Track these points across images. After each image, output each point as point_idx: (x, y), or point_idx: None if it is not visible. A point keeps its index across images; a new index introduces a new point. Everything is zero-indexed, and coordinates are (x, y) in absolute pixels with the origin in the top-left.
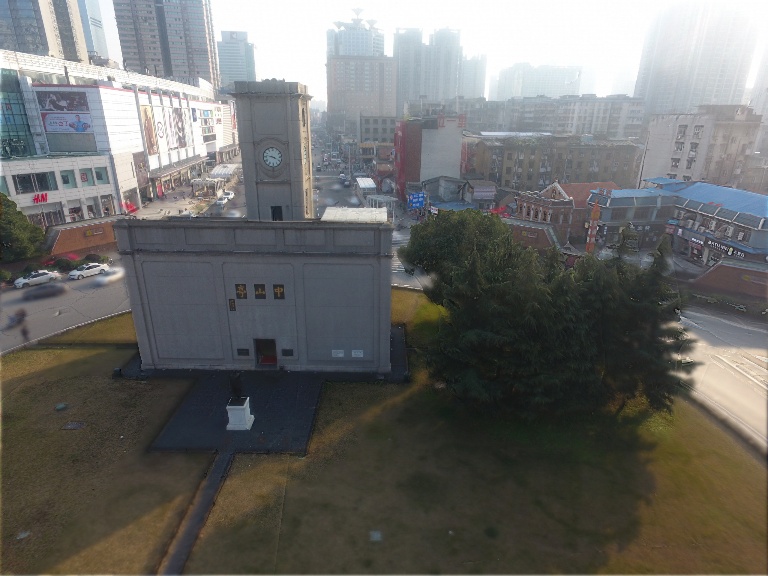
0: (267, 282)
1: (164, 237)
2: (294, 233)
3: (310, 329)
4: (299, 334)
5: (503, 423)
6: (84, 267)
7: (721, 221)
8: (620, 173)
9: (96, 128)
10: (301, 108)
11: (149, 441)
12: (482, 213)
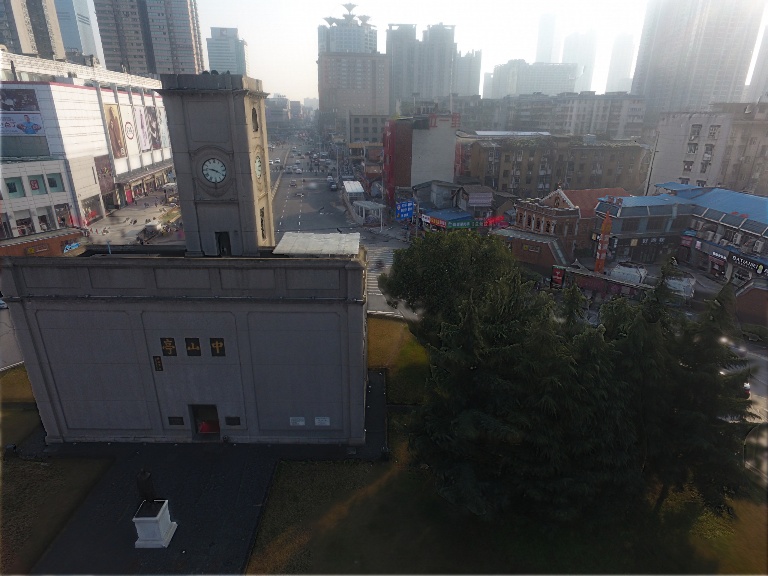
0: (202, 335)
1: (62, 279)
2: (234, 273)
3: (260, 392)
4: (246, 399)
5: (510, 529)
6: None
7: (747, 234)
8: (625, 176)
9: (48, 130)
10: (250, 108)
11: (23, 570)
12: (478, 222)
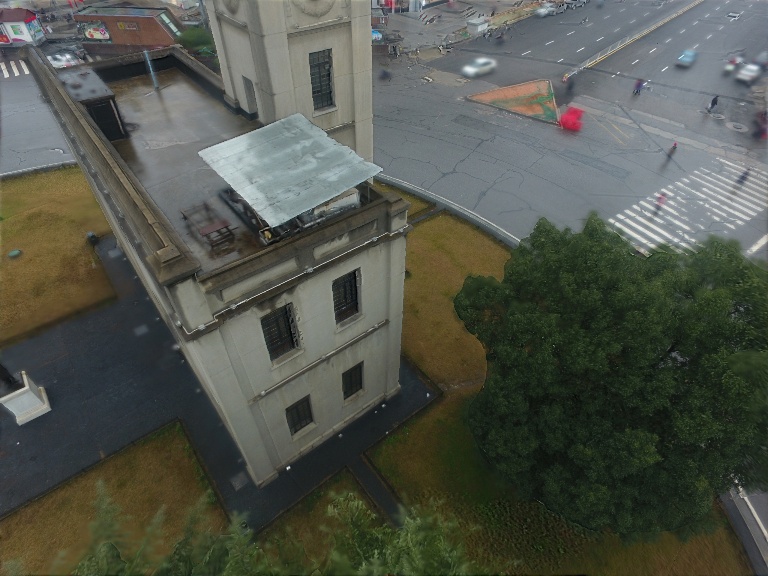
0: None
1: None
2: None
3: None
4: None
5: None
6: None
7: None
8: None
9: None
10: None
11: None
12: None
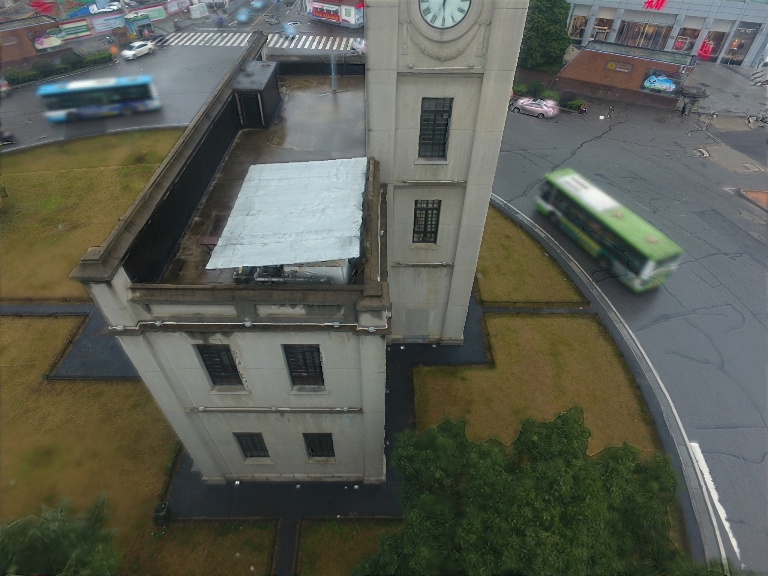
0: None
1: None
2: None
3: None
4: None
5: None
6: (529, 101)
7: None
8: None
9: None
10: None
11: None
12: None
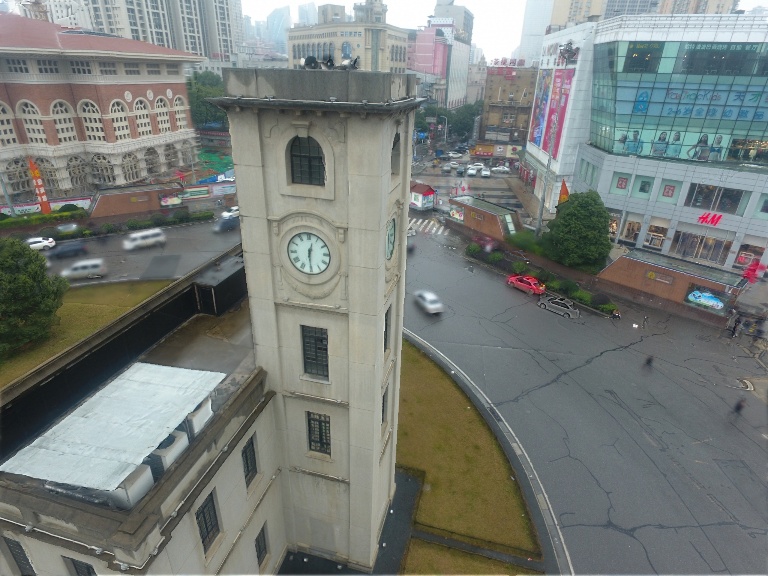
0: None
1: None
2: None
3: None
4: None
5: None
6: (555, 299)
7: None
8: None
9: None
10: (271, 136)
11: None
12: None
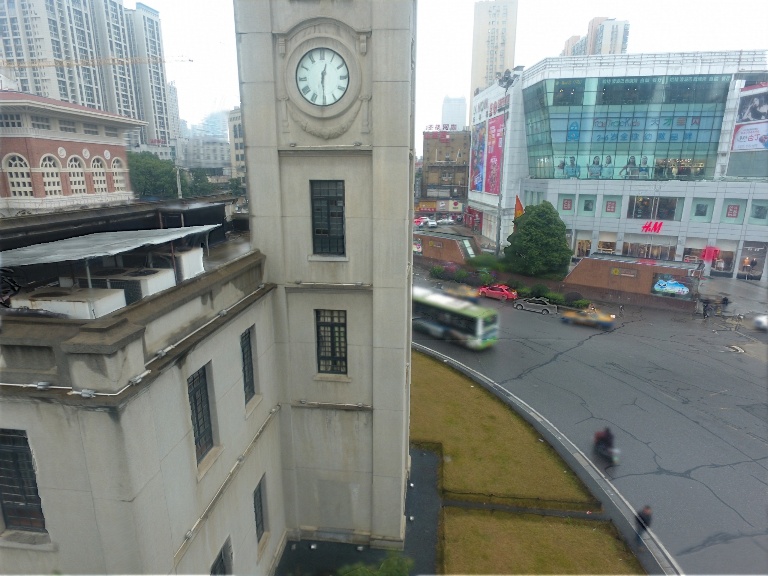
0: None
1: None
2: None
3: None
4: None
5: None
6: (531, 298)
7: None
8: None
9: None
10: None
11: None
12: None
